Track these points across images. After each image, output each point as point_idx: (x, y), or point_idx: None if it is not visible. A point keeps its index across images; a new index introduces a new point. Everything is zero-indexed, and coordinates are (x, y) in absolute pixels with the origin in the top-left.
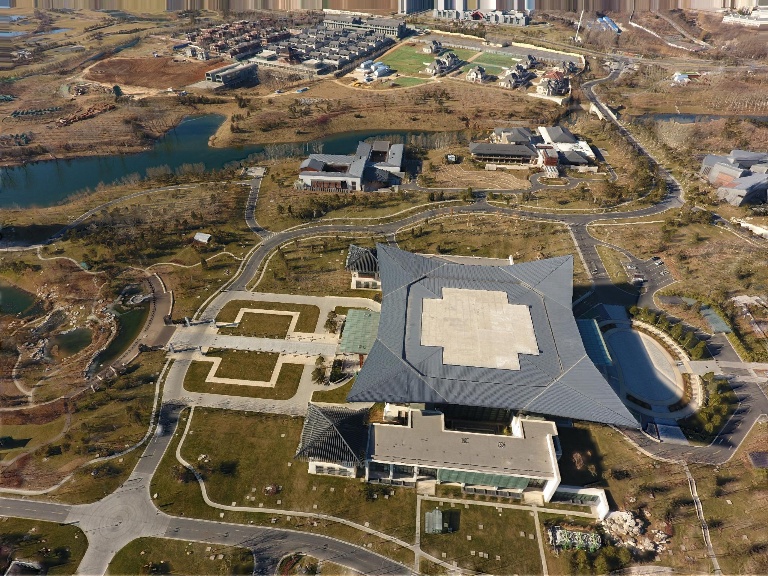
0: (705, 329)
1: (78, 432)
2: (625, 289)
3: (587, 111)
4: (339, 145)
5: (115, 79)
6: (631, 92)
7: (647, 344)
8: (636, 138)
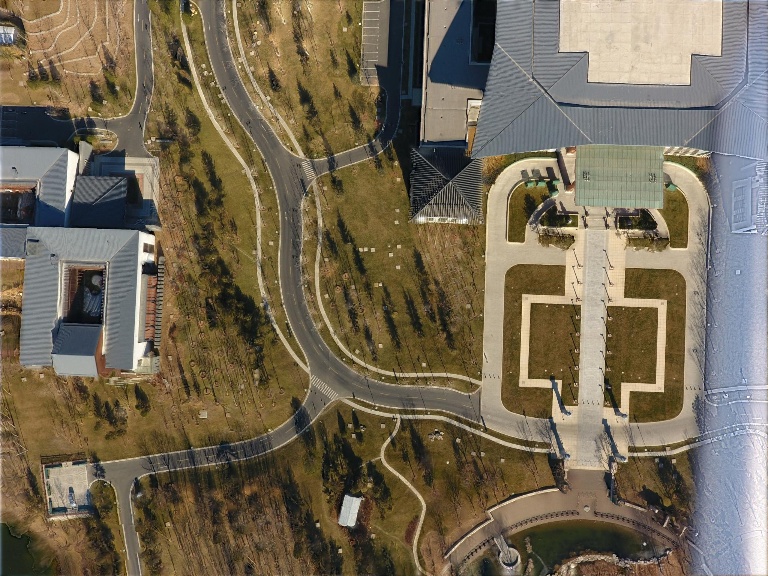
0: None
1: (760, 516)
2: None
3: None
4: None
5: None
6: None
7: None
8: None
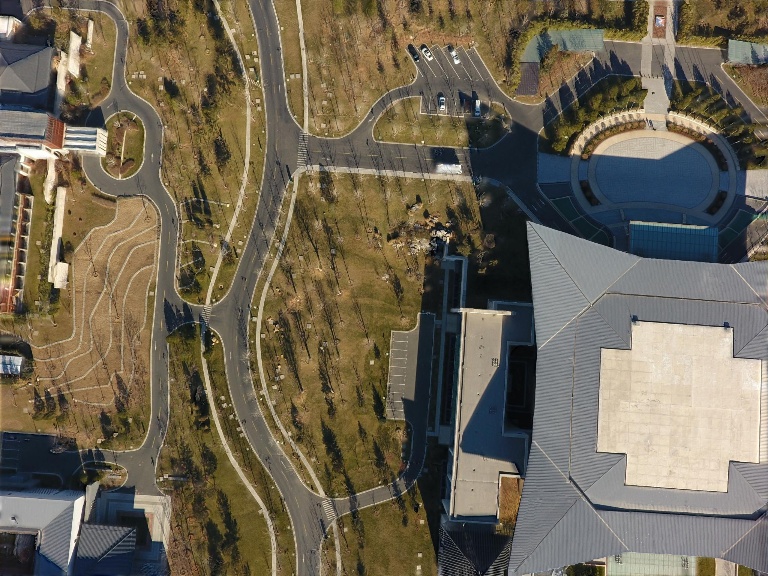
0: (583, 59)
1: None
2: (500, 136)
3: None
4: None
5: None
6: None
7: (618, 152)
8: None
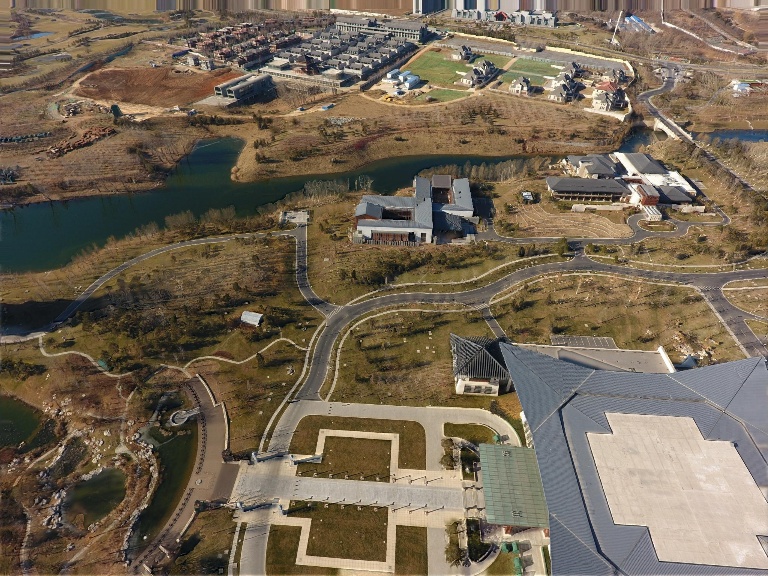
0: None
1: None
2: None
3: (651, 128)
4: (382, 175)
5: (111, 95)
6: (694, 105)
7: None
8: (726, 164)
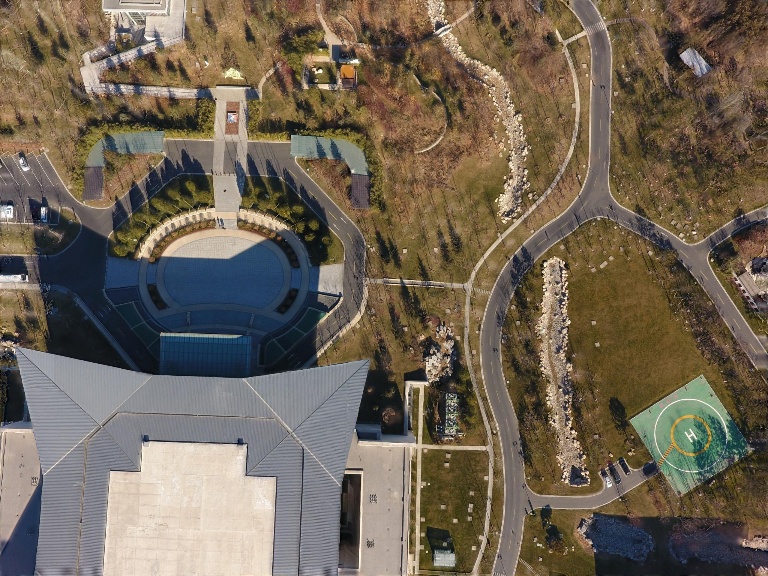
0: (153, 160)
1: None
2: (67, 242)
3: None
4: None
5: None
6: None
7: (187, 253)
8: None
